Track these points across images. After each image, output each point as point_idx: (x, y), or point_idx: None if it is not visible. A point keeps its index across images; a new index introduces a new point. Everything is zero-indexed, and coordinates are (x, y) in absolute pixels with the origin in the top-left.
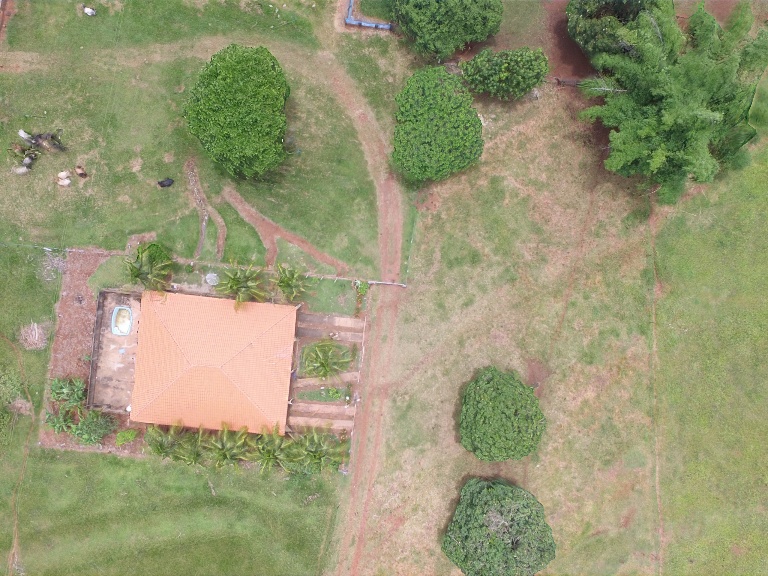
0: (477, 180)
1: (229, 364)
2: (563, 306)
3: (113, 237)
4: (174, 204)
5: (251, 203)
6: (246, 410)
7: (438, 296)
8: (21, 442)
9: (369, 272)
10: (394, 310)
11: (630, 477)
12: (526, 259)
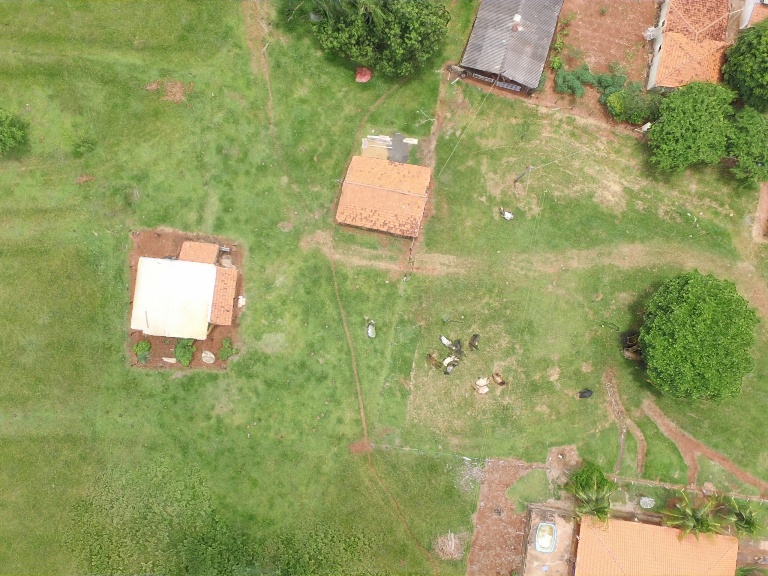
0: None
1: None
2: None
3: (534, 449)
4: (593, 416)
5: (671, 418)
6: None
7: None
8: None
9: None
10: None
11: None
12: None
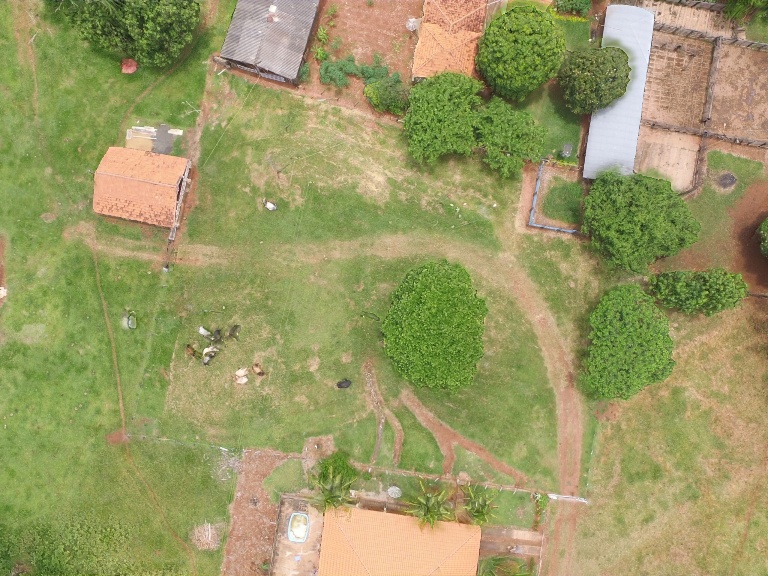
0: (658, 391)
1: None
2: (745, 525)
3: (290, 439)
4: (351, 406)
5: (429, 407)
6: None
7: (618, 511)
8: None
9: (548, 484)
10: (572, 523)
11: None
12: (708, 475)
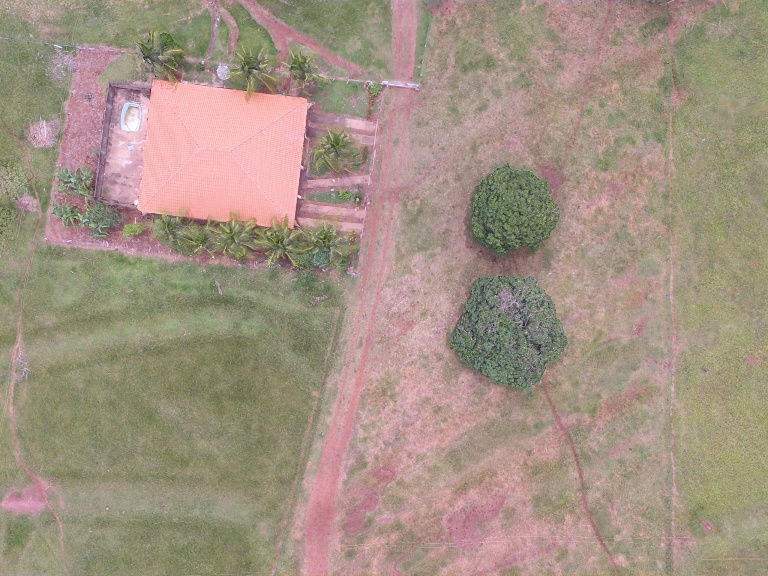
0: None
1: (239, 149)
2: (578, 113)
3: (124, 35)
4: (186, 5)
5: (264, 5)
6: (255, 200)
7: (451, 101)
8: (27, 238)
9: (382, 75)
10: (406, 114)
11: (644, 286)
12: (541, 65)
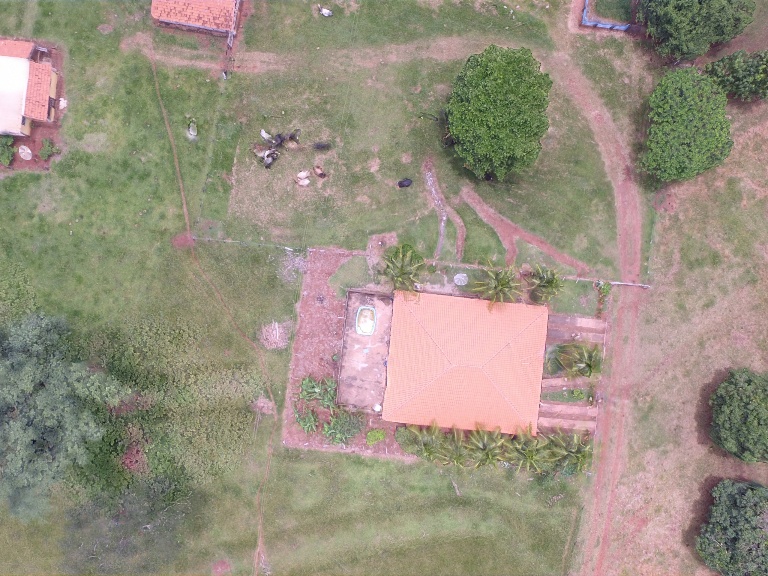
0: (714, 181)
1: (489, 364)
2: None
3: (354, 237)
4: (413, 204)
5: (489, 203)
6: (501, 410)
7: (678, 297)
8: (265, 441)
9: (609, 273)
10: (634, 311)
11: None
12: (766, 260)
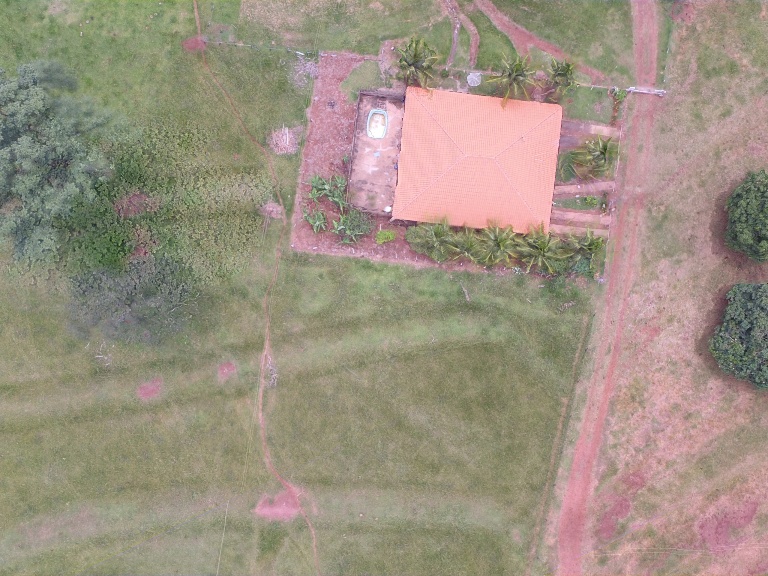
0: None
1: (502, 156)
2: None
3: (366, 42)
4: (426, 11)
5: (504, 11)
6: (513, 207)
7: (694, 107)
8: (273, 245)
9: (625, 81)
10: (650, 120)
11: None
12: None
